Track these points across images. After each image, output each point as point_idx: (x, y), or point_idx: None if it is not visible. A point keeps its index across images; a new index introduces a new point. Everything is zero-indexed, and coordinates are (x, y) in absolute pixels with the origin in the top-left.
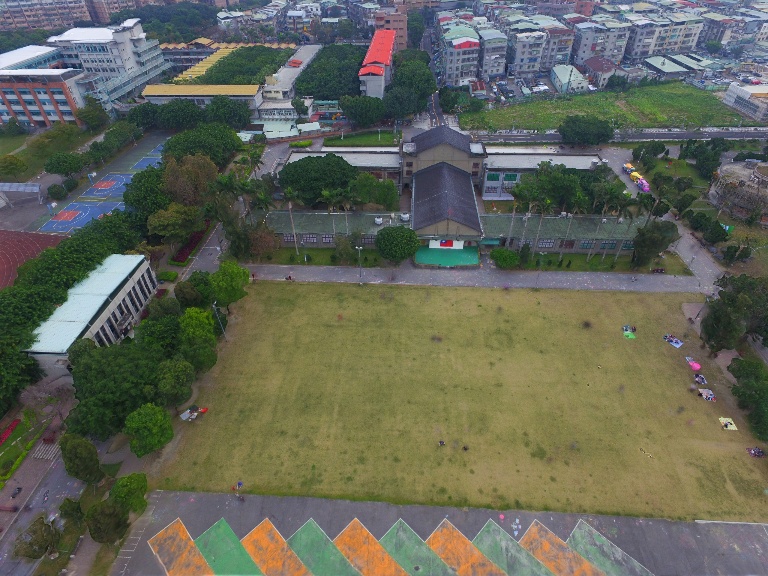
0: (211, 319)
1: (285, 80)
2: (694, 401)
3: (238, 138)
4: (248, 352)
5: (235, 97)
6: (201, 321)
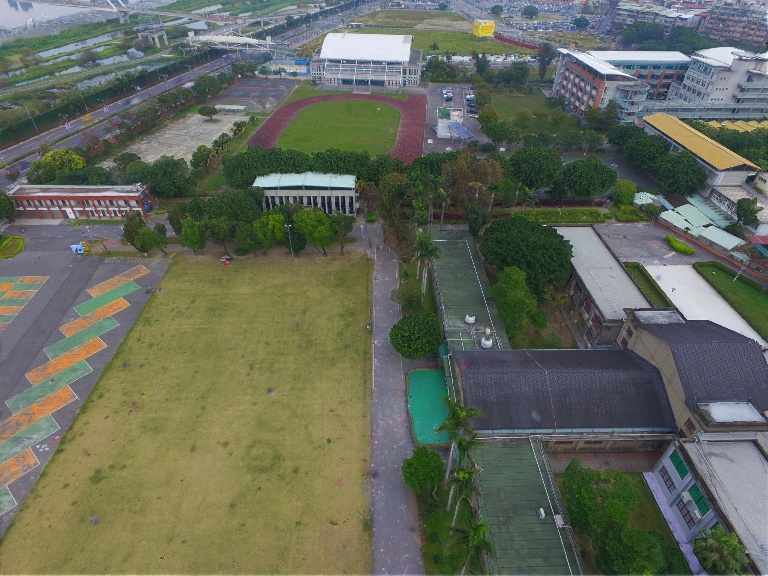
0: (278, 230)
1: None
2: None
3: (624, 193)
4: (279, 272)
5: (702, 161)
6: (269, 224)
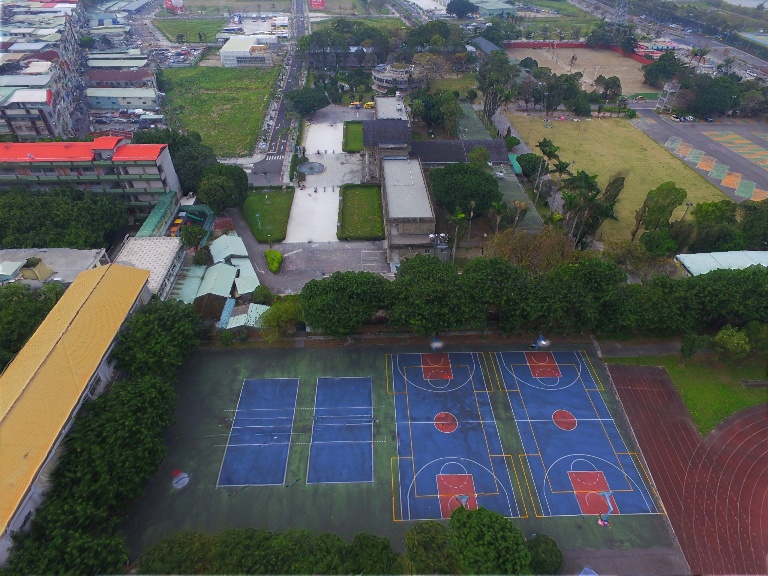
0: None
1: (23, 263)
2: (583, 122)
3: None
4: None
5: (132, 306)
6: None
